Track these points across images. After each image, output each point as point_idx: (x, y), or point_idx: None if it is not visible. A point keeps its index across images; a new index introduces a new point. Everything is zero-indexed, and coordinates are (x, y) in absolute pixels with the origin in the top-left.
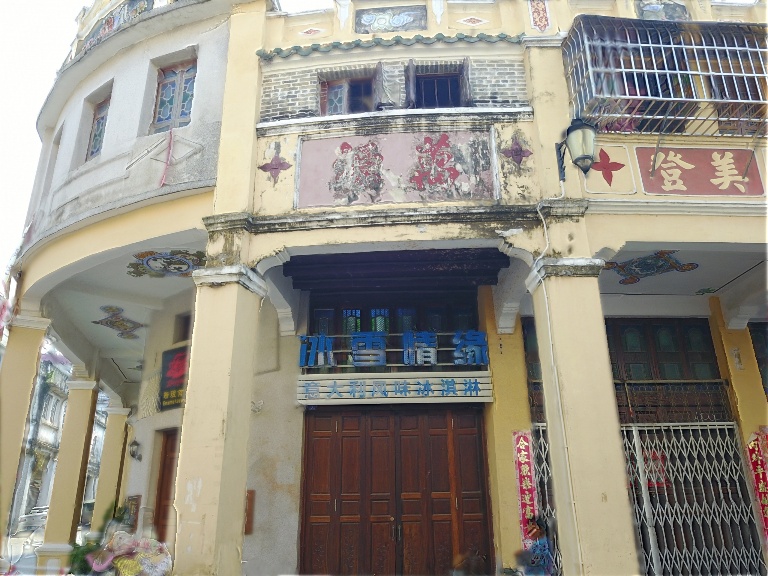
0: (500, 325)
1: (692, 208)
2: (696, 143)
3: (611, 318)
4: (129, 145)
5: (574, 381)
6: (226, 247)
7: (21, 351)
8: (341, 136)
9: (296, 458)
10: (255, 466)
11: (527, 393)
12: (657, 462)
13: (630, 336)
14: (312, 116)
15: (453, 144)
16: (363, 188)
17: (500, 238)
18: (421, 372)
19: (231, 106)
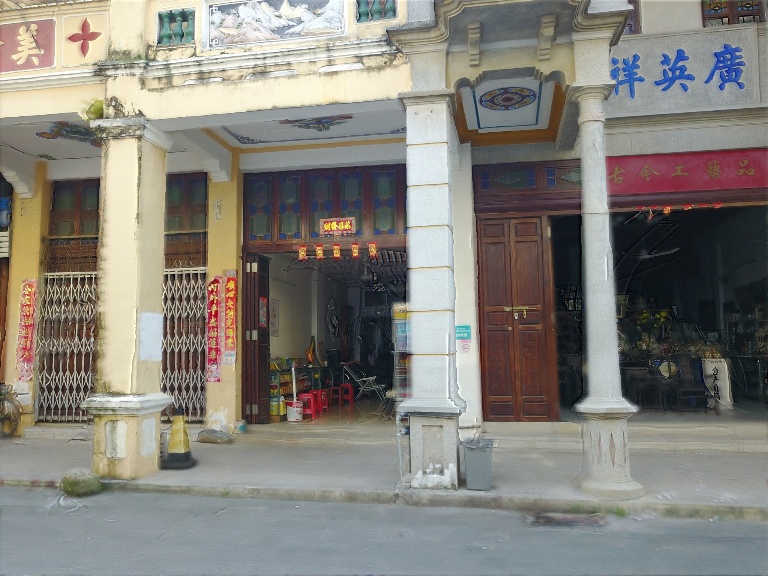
0: (17, 191)
1: None
2: (9, 18)
3: None
4: None
5: None
6: None
7: None
8: None
9: None
10: None
11: (39, 248)
12: None
13: None
14: None
15: None
16: None
17: None
18: None
19: None
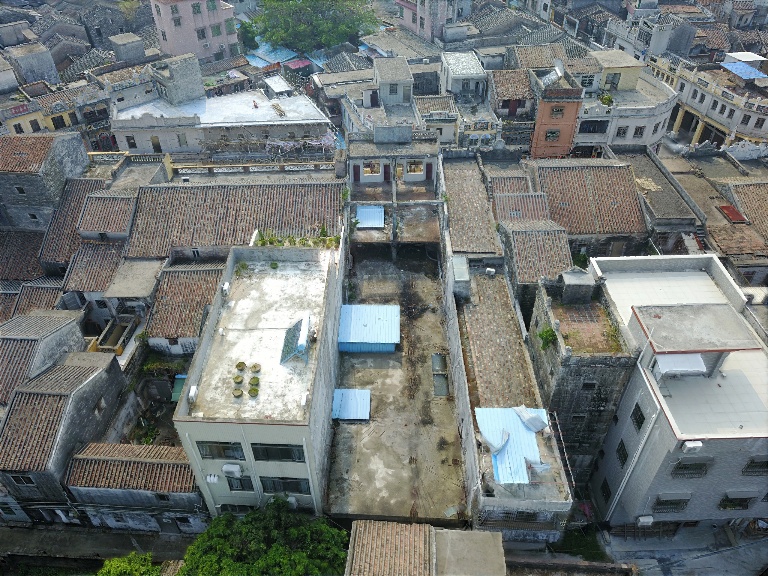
0: None
1: None
2: None
3: None
4: (767, 131)
5: None
6: None
7: None
8: None
9: None
10: None
11: None
12: None
13: None
14: None
15: None
16: None
17: None
18: None
19: None
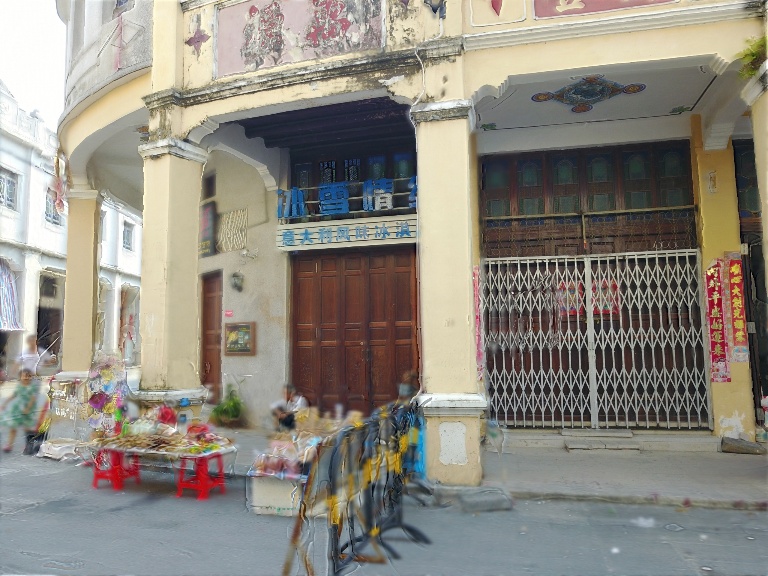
0: None
1: (580, 29)
2: None
3: (577, 149)
4: (98, 33)
5: (432, 222)
6: (161, 122)
7: (80, 218)
8: None
9: (282, 295)
10: (254, 302)
11: (478, 231)
12: (606, 291)
13: (597, 166)
14: None
15: None
16: (268, 51)
17: (384, 87)
18: (379, 217)
19: None
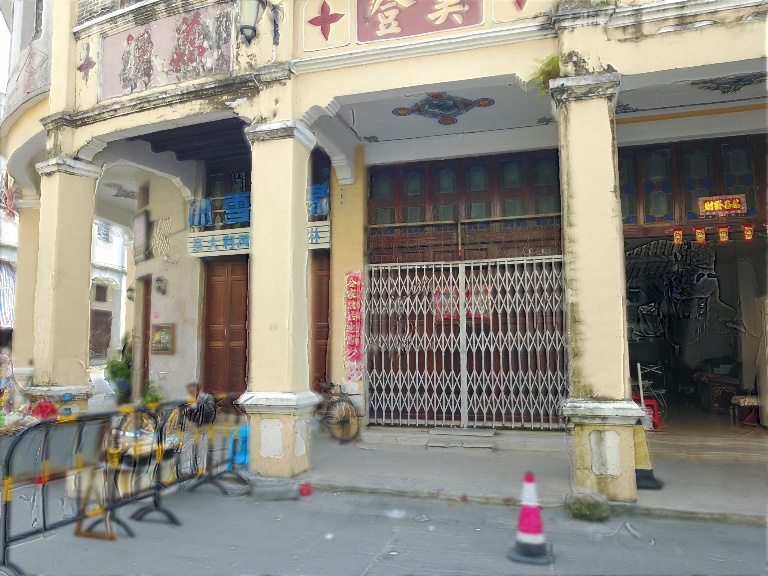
0: (338, 177)
1: (392, 53)
2: None
3: (456, 158)
4: (17, 60)
5: (261, 234)
6: (55, 142)
7: (29, 226)
8: (127, 29)
9: (195, 298)
10: (174, 305)
11: (362, 238)
12: (478, 295)
13: (475, 175)
14: (108, 13)
15: (203, 21)
16: (140, 76)
17: (230, 109)
18: None
19: (56, 15)
